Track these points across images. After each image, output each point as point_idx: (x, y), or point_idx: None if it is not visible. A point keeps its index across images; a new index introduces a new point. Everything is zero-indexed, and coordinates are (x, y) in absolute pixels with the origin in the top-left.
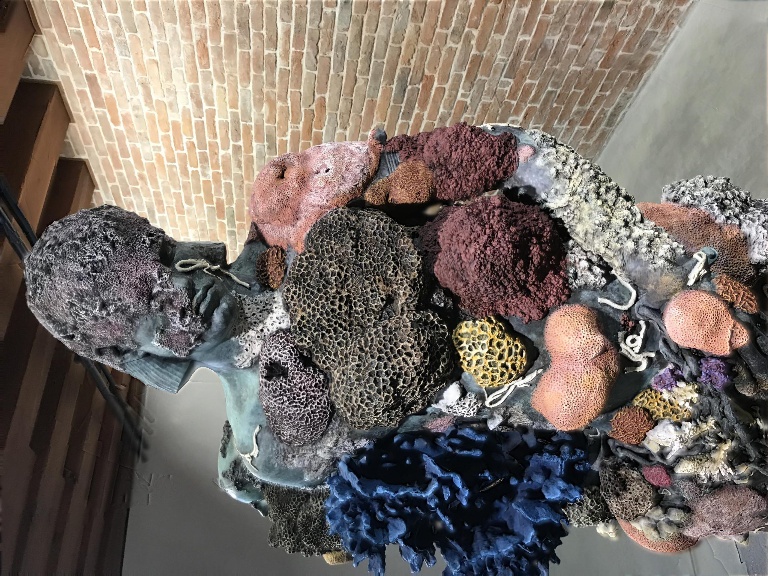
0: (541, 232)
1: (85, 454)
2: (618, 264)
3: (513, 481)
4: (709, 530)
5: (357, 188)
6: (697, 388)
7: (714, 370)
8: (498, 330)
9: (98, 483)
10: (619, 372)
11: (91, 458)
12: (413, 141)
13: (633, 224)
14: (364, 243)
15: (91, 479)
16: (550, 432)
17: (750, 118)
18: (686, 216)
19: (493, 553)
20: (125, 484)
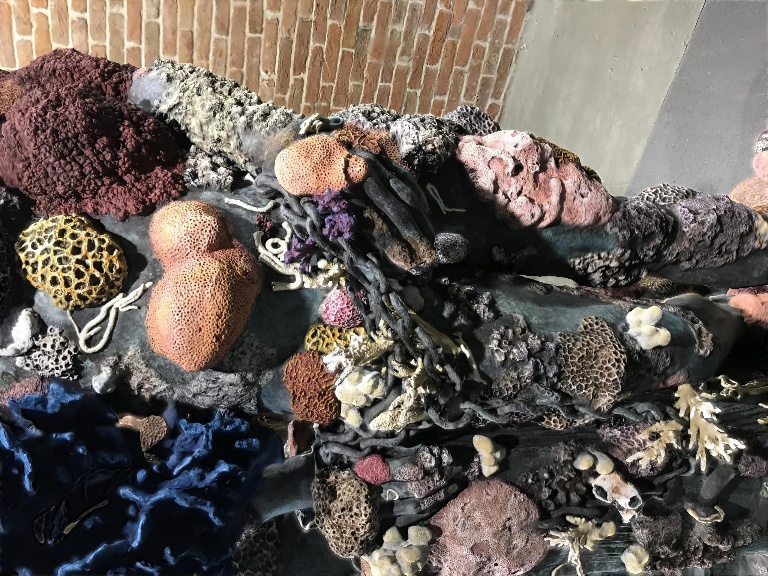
0: (141, 121)
1: None
2: (233, 144)
3: (140, 474)
4: (475, 562)
5: None
6: (345, 269)
7: (332, 205)
8: (75, 221)
9: None
10: (265, 288)
11: None
12: None
13: (248, 105)
14: None
15: None
16: (211, 416)
17: None
18: None
19: (74, 565)
20: None
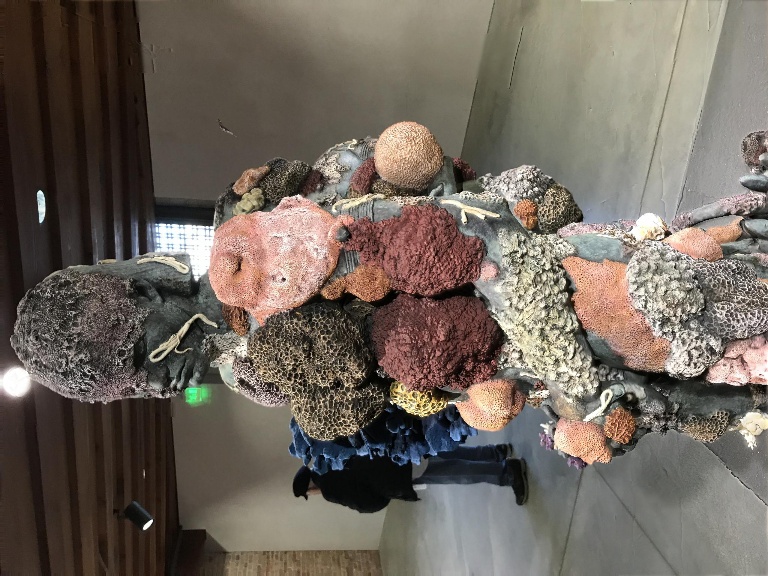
0: (479, 349)
1: (79, 19)
2: (539, 378)
3: None
4: None
5: (313, 293)
6: None
7: None
8: (426, 398)
9: (100, 45)
10: None
11: (87, 22)
12: (376, 237)
13: (563, 360)
14: (316, 353)
15: (92, 39)
16: None
17: None
18: (629, 322)
19: (405, 458)
20: (127, 48)
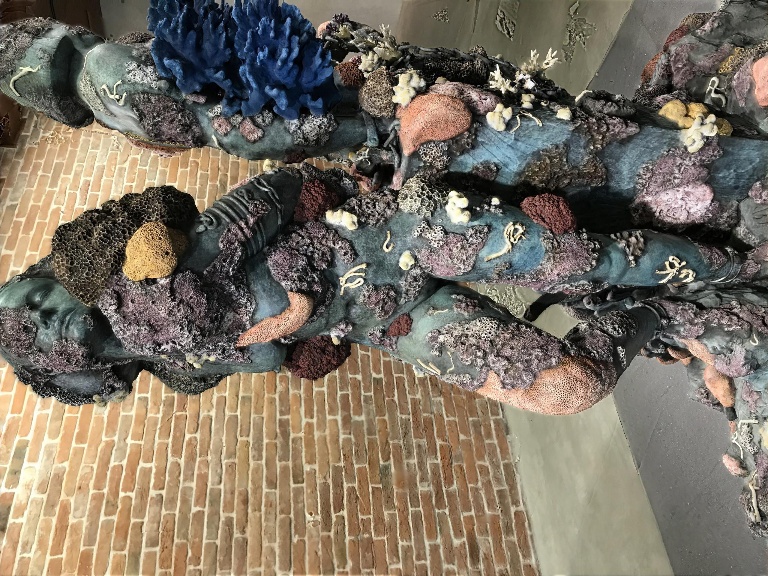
0: None
1: None
2: None
3: None
4: (455, 87)
5: None
6: None
7: None
8: None
9: None
10: None
11: None
12: None
13: None
14: None
15: None
16: None
17: (627, 575)
18: None
19: None
20: None
